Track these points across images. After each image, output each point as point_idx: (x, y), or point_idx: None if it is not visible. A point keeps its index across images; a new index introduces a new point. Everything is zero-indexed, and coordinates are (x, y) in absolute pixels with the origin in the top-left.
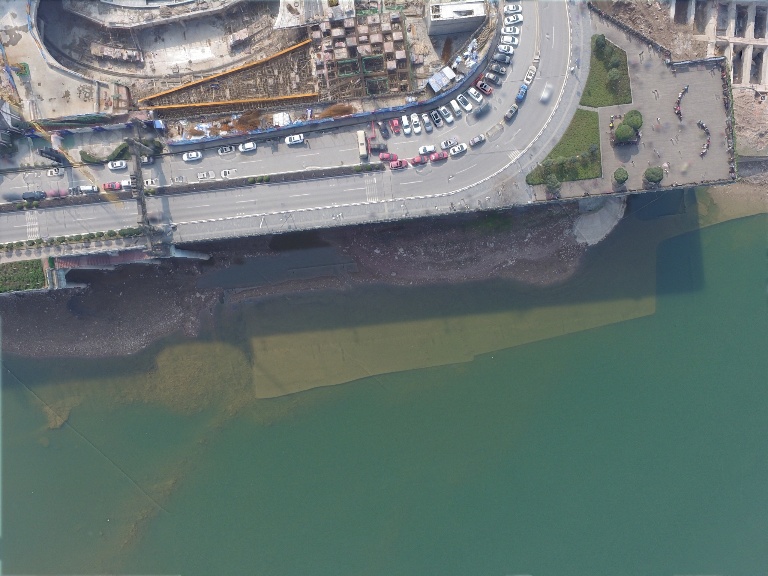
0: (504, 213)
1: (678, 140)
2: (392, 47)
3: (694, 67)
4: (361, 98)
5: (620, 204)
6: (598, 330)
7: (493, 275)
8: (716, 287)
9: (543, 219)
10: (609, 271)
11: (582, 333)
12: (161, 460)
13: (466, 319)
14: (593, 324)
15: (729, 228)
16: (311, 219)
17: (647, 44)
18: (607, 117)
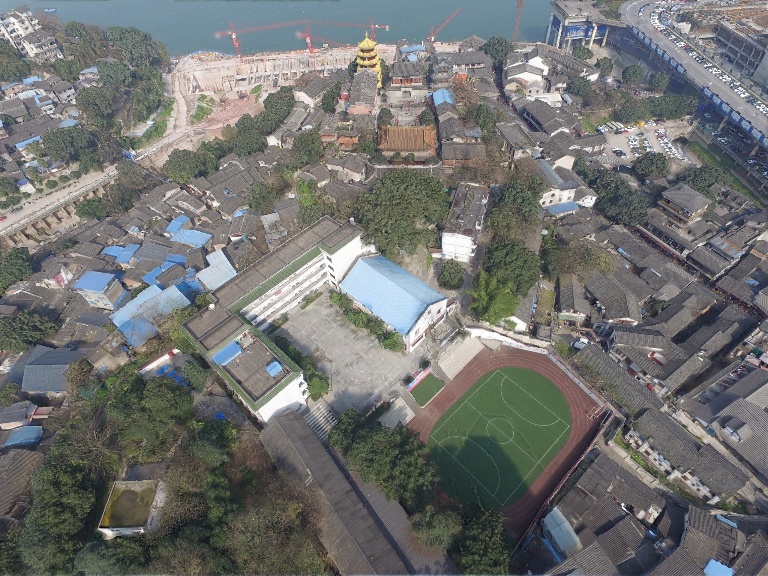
0: None
1: None
2: None
3: None
4: (704, 8)
5: None
6: None
7: None
8: None
9: None
10: None
11: None
12: None
13: None
14: None
15: None
16: None
17: None
18: (606, 8)
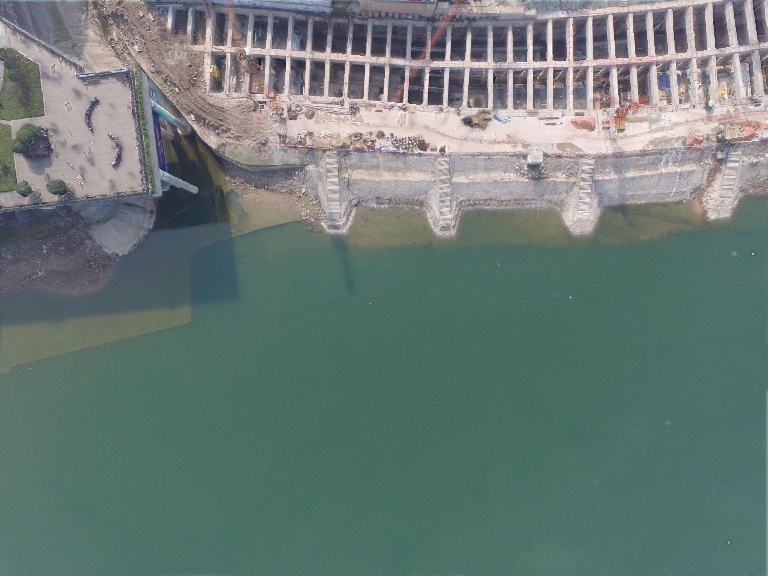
0: (5, 225)
1: (91, 152)
2: None
3: (105, 79)
4: None
5: (145, 214)
6: (134, 340)
7: (25, 286)
8: (250, 296)
9: (52, 230)
10: (143, 281)
11: (118, 343)
12: None
13: (2, 330)
14: (128, 334)
15: (262, 237)
16: None
17: (59, 57)
18: None
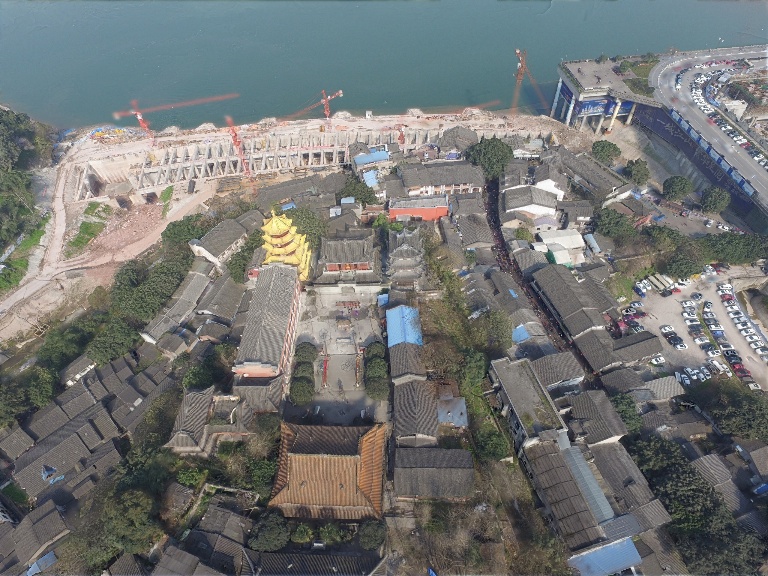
0: None
1: None
2: (757, 92)
3: None
4: (760, 76)
5: None
6: None
7: None
8: (512, 90)
9: None
10: None
11: None
12: (753, 42)
13: None
14: None
15: None
16: (754, 49)
17: None
18: None
